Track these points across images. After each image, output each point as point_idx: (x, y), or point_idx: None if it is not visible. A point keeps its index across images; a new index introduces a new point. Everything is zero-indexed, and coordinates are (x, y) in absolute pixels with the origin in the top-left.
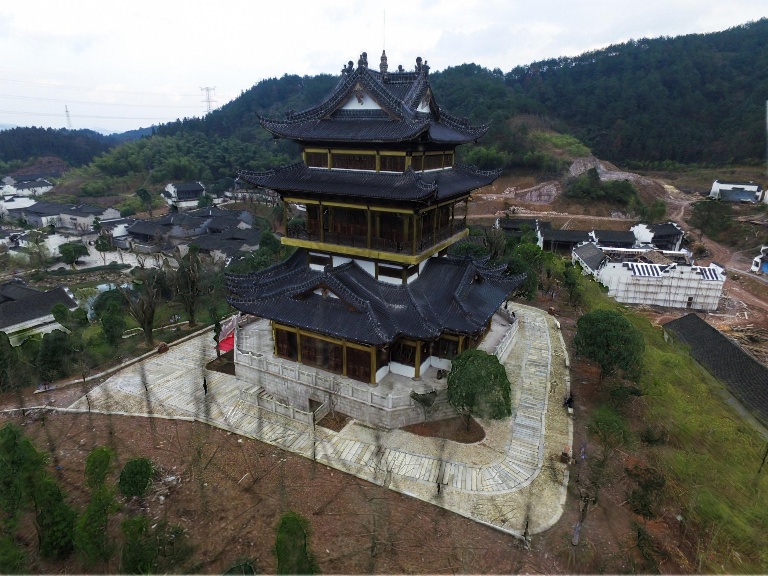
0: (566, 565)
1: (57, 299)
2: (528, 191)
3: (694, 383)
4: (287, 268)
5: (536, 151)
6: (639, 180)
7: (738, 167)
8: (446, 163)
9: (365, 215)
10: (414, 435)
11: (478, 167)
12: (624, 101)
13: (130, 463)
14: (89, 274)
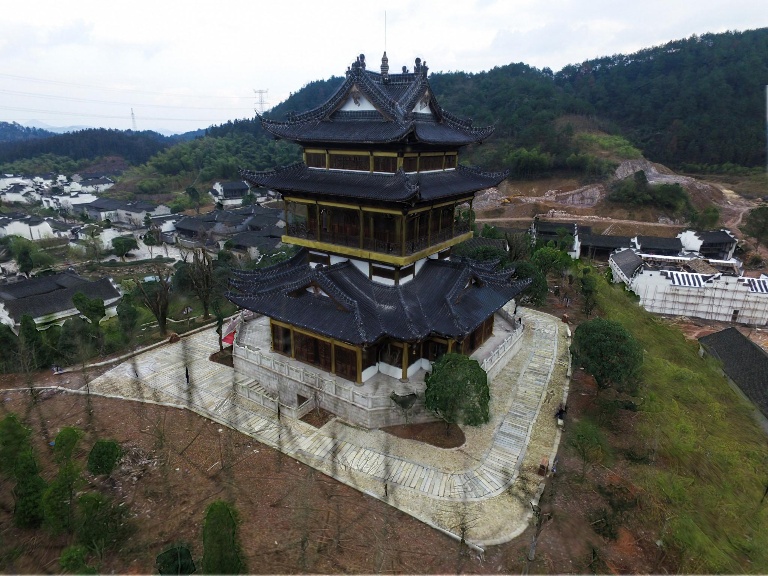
0: None
1: (102, 289)
2: (570, 194)
3: (707, 401)
4: (291, 266)
5: (580, 153)
6: (694, 184)
7: None
8: (448, 164)
9: (358, 215)
10: (393, 436)
11: (518, 169)
12: (682, 100)
13: (98, 443)
14: (137, 266)
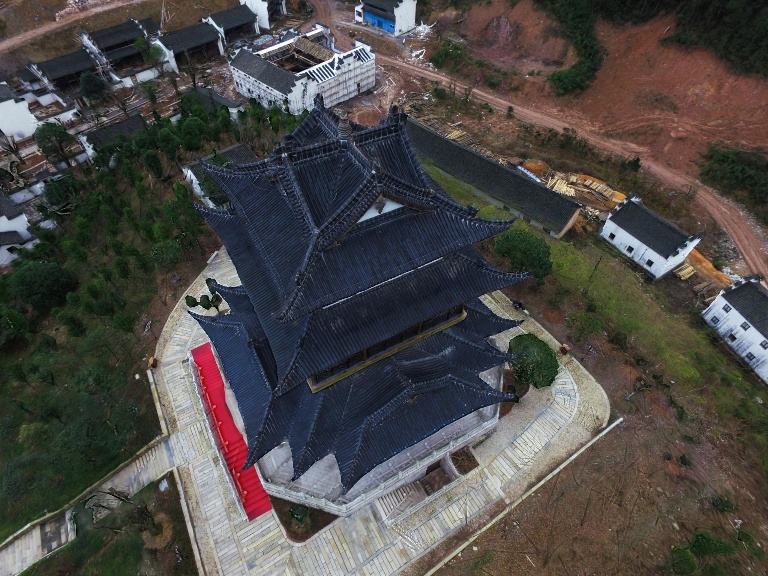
0: (634, 412)
1: None
2: None
3: (520, 225)
4: None
5: None
6: None
7: None
8: None
9: None
10: (506, 416)
11: None
12: None
13: None
14: None
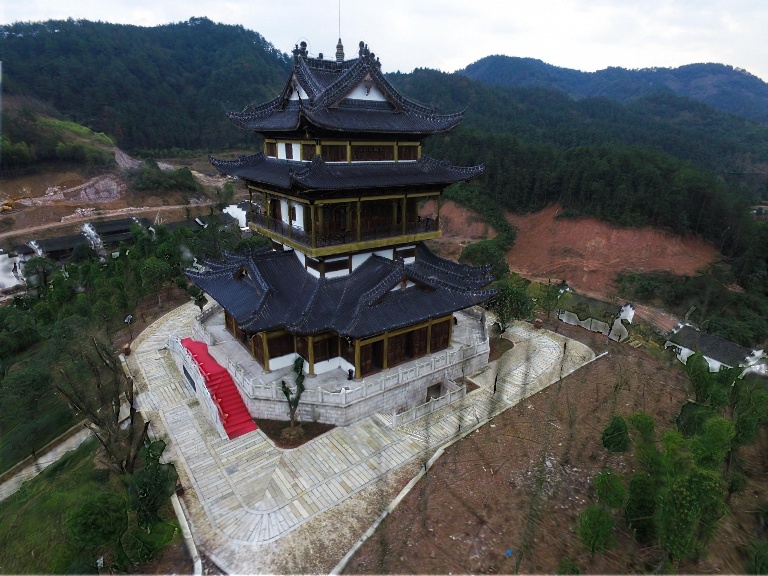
0: (617, 353)
1: None
2: (80, 189)
3: None
4: None
5: (67, 141)
6: None
7: (234, 151)
8: None
9: None
10: (498, 360)
11: None
12: (101, 86)
13: (622, 423)
14: None
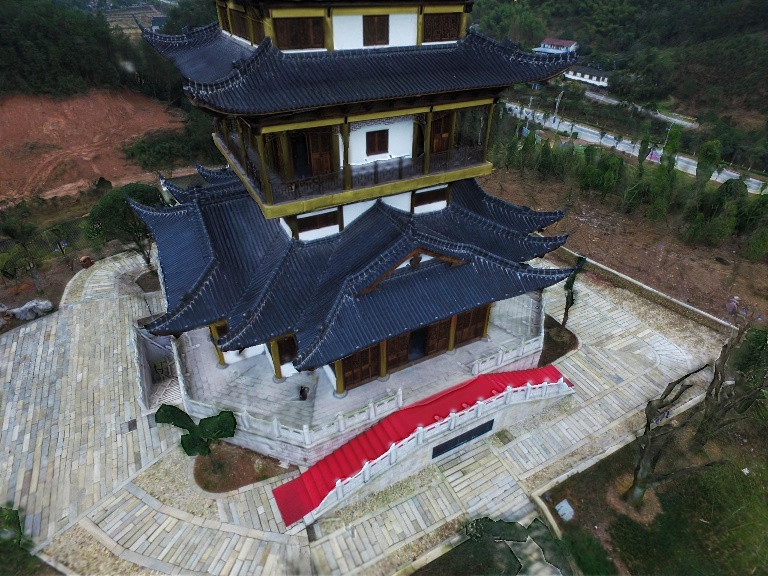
0: None
1: None
2: None
3: None
4: None
5: None
6: None
7: None
8: None
9: None
10: None
11: None
12: None
13: None
14: None
